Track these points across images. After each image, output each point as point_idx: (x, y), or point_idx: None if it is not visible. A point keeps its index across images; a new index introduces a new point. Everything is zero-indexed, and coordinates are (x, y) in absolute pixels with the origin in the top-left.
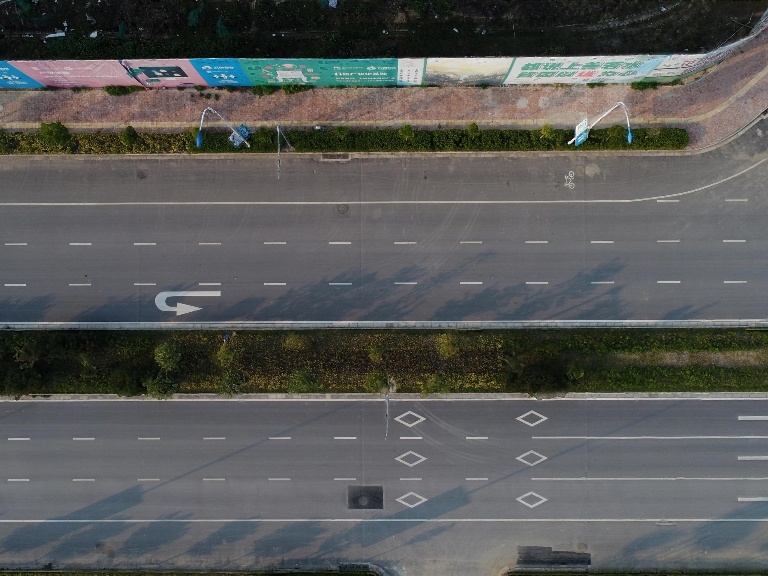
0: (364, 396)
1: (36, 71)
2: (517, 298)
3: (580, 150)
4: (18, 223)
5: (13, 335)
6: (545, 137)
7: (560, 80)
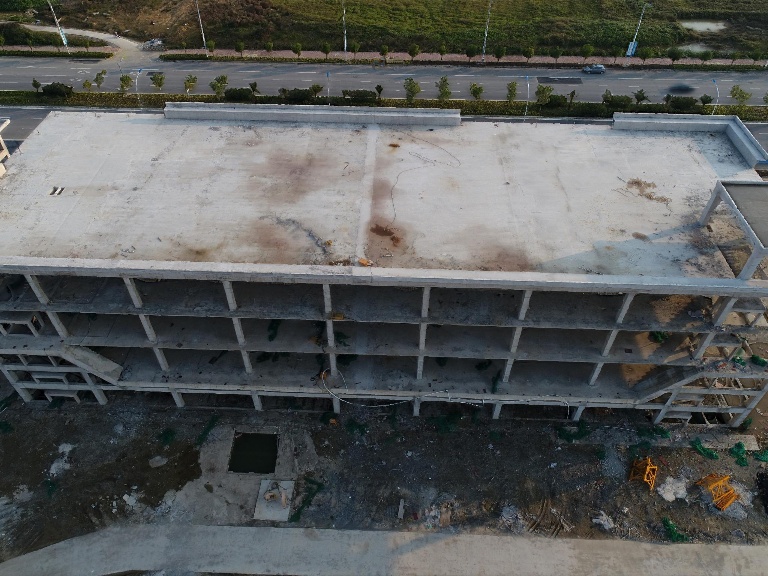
0: None
1: None
2: None
3: None
4: None
5: None
6: None
7: None
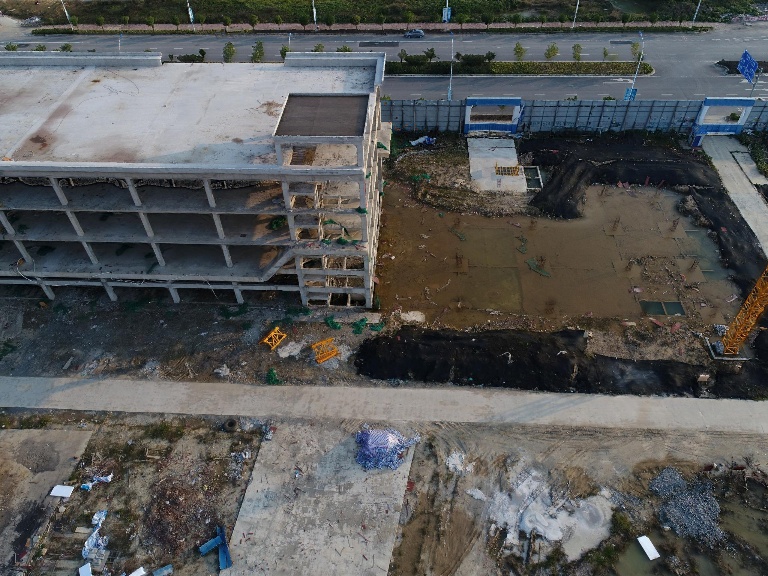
0: None
1: None
2: None
3: None
4: None
5: None
6: None
7: None
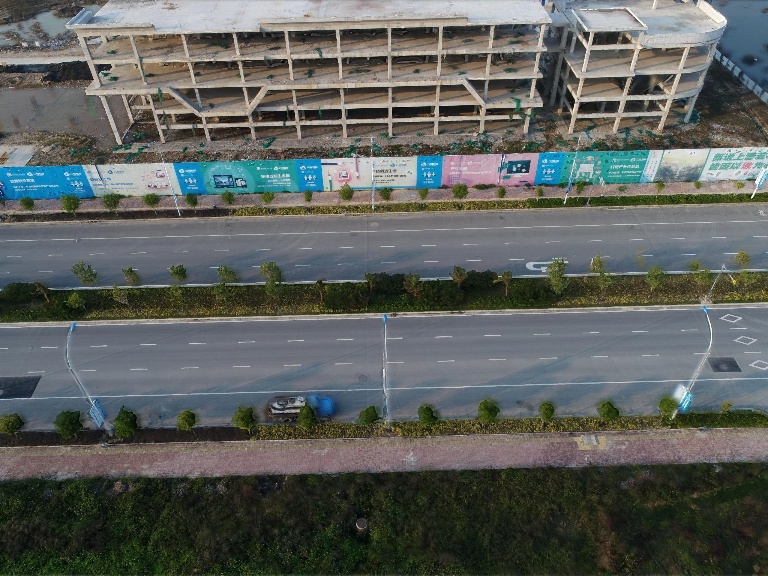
0: (691, 307)
1: (450, 167)
2: (765, 259)
3: (759, 202)
4: (429, 237)
5: (437, 279)
6: (736, 196)
7: (731, 175)
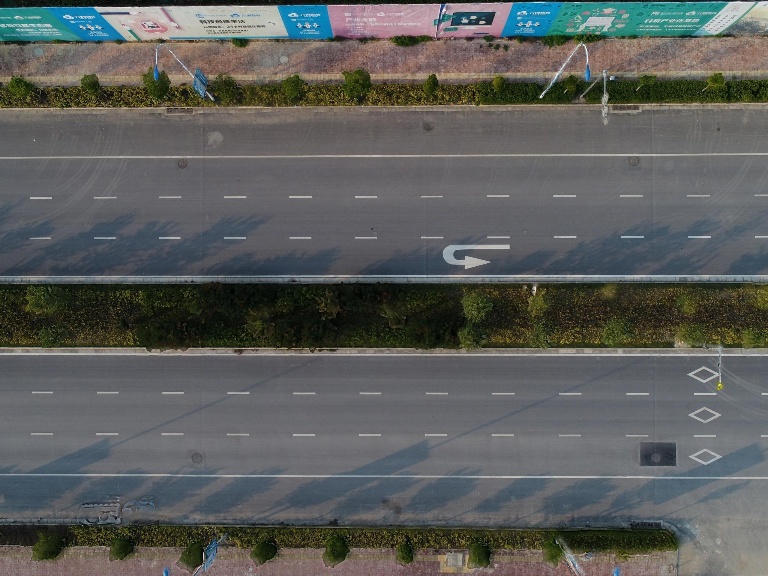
0: (657, 351)
1: (344, 18)
2: None
3: None
4: (302, 175)
5: (303, 288)
6: None
7: None
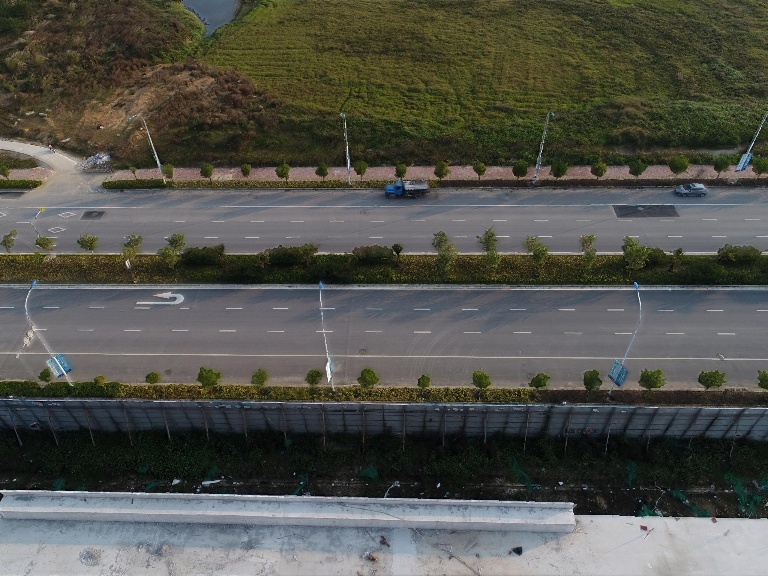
0: None
1: None
2: None
3: None
4: (272, 344)
5: None
6: None
7: None
